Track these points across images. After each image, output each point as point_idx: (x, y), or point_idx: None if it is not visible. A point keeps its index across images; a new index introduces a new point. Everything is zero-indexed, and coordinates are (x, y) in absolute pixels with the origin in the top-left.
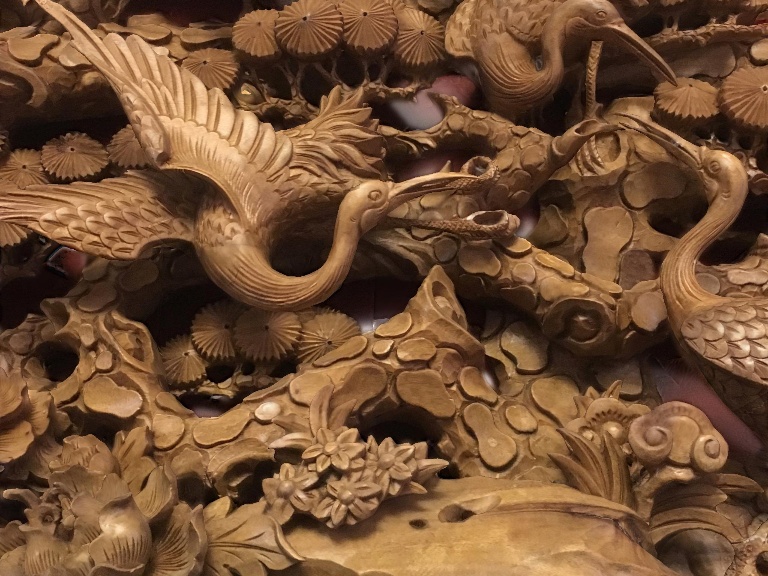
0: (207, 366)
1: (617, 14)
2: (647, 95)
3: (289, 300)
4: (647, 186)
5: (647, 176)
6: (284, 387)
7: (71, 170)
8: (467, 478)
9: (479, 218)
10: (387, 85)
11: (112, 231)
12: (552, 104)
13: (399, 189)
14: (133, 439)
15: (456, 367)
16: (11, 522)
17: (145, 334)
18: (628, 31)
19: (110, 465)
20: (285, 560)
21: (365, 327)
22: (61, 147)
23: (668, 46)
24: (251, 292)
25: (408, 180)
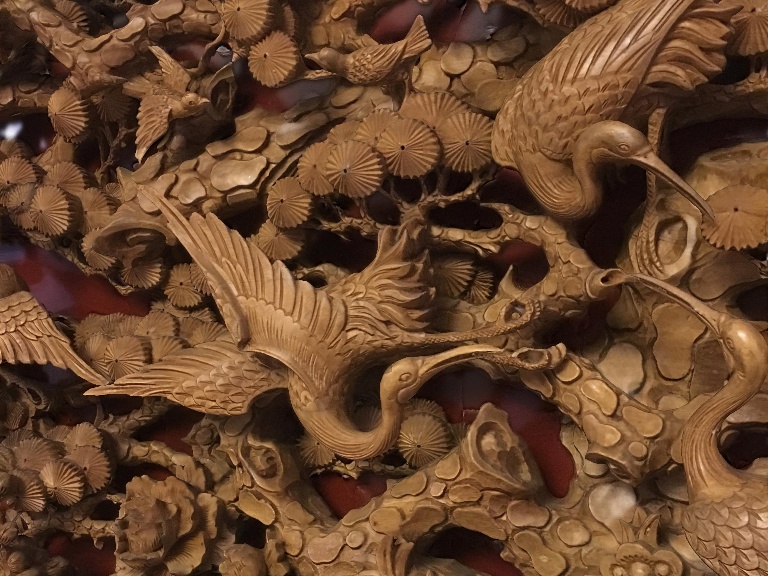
0: None
1: (642, 144)
2: (741, 142)
3: (356, 457)
4: (721, 276)
5: (719, 267)
6: (366, 518)
7: None
8: None
9: (523, 355)
10: (445, 194)
11: (224, 396)
12: (630, 167)
13: (428, 366)
14: (270, 549)
15: (504, 502)
16: None
17: (274, 451)
18: (655, 162)
19: (255, 572)
20: None
21: (457, 416)
22: None
23: (757, 93)
24: (328, 448)
25: (436, 356)
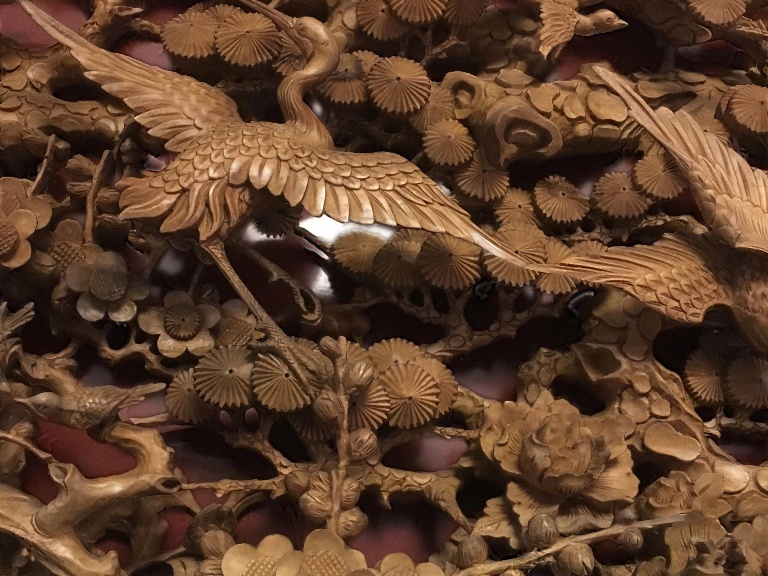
0: (695, 407)
1: None
2: None
3: None
4: None
5: None
6: None
7: (565, 214)
8: None
9: None
10: None
11: (687, 297)
12: None
13: None
14: (708, 483)
15: None
16: (659, 558)
17: (681, 383)
18: None
19: None
20: None
21: None
22: (552, 191)
23: None
24: None
25: None
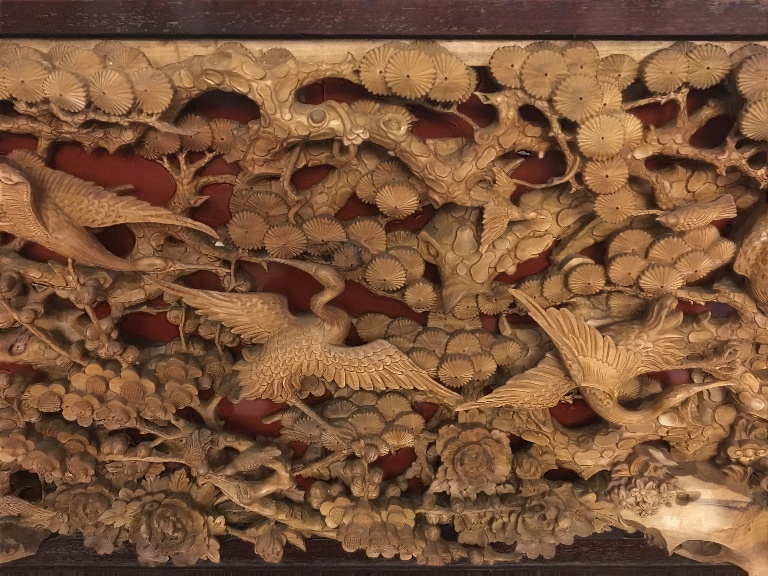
0: None
1: None
2: None
3: None
4: None
5: None
6: None
7: (496, 311)
8: (686, 476)
9: None
10: None
11: None
12: None
13: (695, 392)
14: (548, 459)
15: None
16: None
17: None
18: None
19: (541, 472)
20: (621, 524)
21: None
22: (489, 298)
23: None
24: None
25: (700, 387)
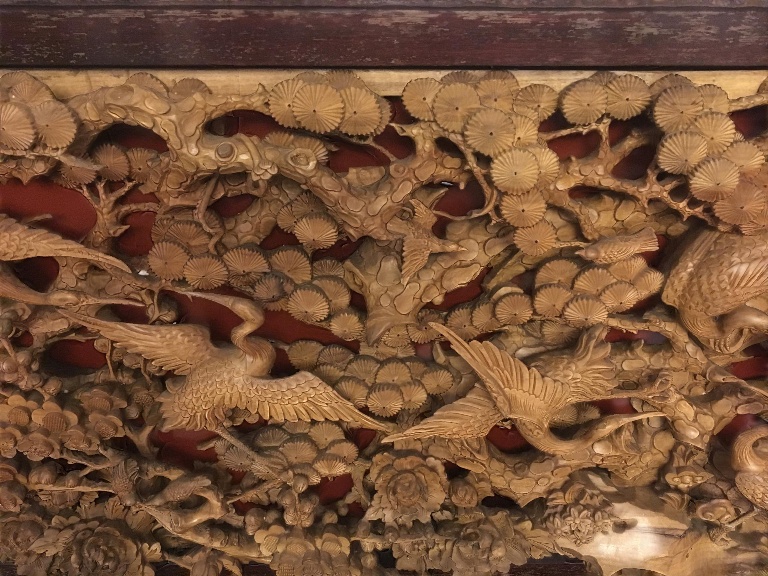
0: None
1: None
2: None
3: (560, 454)
4: None
5: None
6: None
7: (426, 339)
8: (623, 504)
9: None
10: None
11: (478, 431)
12: None
13: (624, 423)
14: (484, 487)
15: None
16: None
17: None
18: None
19: None
20: None
21: None
22: (419, 326)
23: None
24: None
25: (630, 418)
